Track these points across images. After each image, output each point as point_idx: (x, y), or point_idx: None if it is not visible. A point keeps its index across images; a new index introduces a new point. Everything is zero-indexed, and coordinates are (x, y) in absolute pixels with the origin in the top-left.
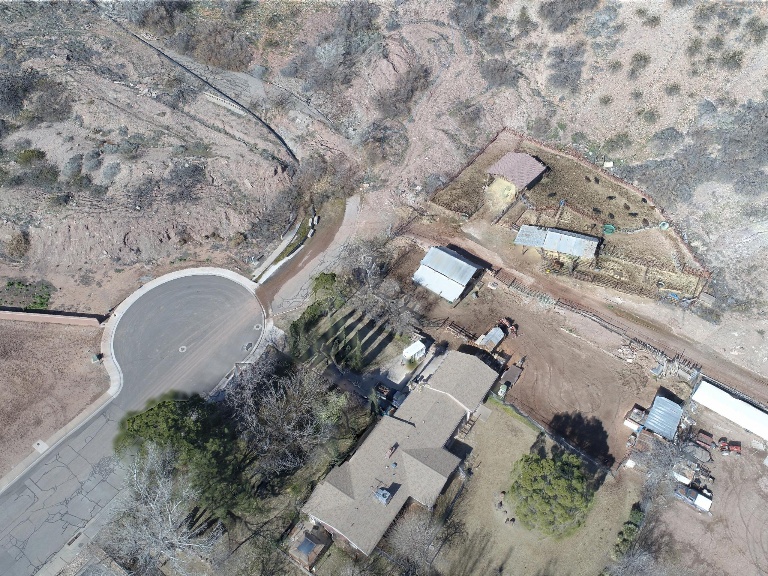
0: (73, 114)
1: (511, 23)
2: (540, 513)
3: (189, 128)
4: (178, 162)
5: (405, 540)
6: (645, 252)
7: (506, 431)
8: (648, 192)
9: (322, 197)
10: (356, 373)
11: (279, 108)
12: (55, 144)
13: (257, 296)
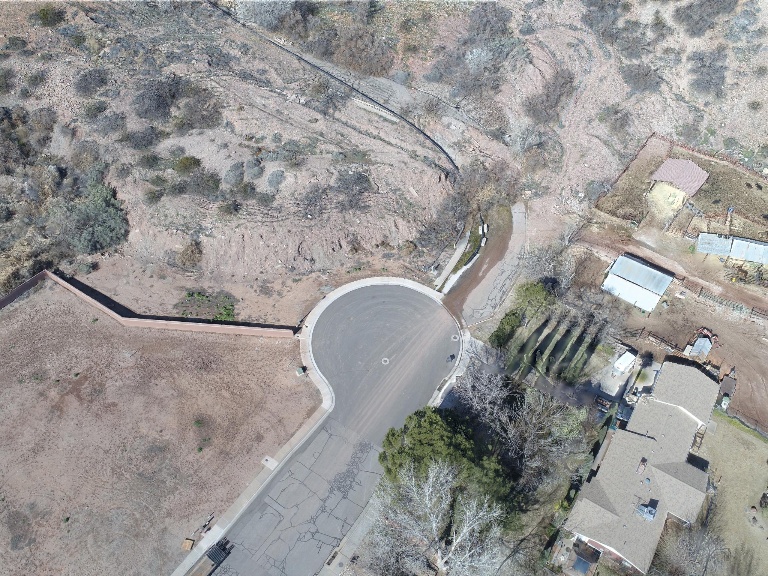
0: (223, 121)
1: (645, 27)
2: None
3: (343, 135)
4: (341, 169)
5: (675, 558)
6: None
7: (737, 444)
8: None
9: (489, 205)
10: (568, 385)
11: (431, 114)
12: (210, 151)
13: (445, 306)
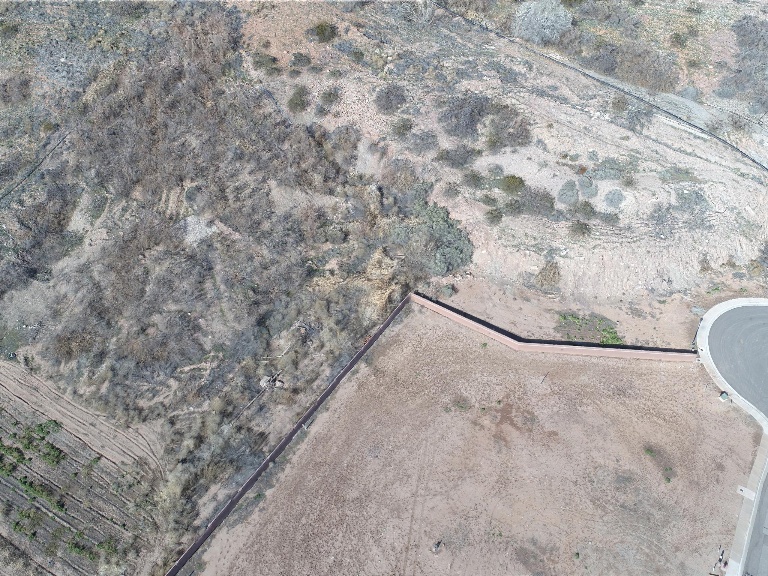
0: (534, 138)
1: None
2: None
3: (657, 152)
4: (676, 188)
5: None
6: None
7: None
8: None
9: None
10: None
11: (740, 131)
12: (530, 170)
13: None
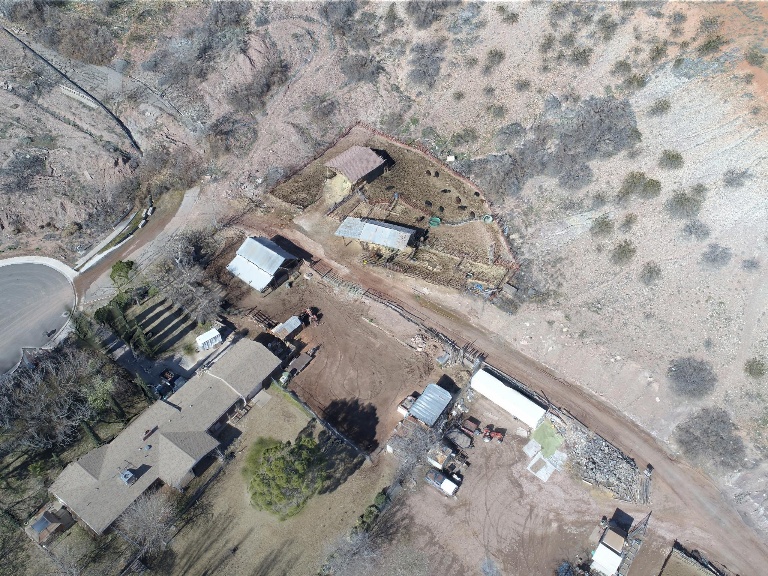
0: None
1: (379, 19)
2: (258, 493)
3: (40, 120)
4: (20, 153)
5: (143, 520)
6: (464, 244)
7: (280, 416)
8: (481, 186)
9: (159, 188)
10: (149, 359)
11: (131, 101)
12: None
13: (74, 284)
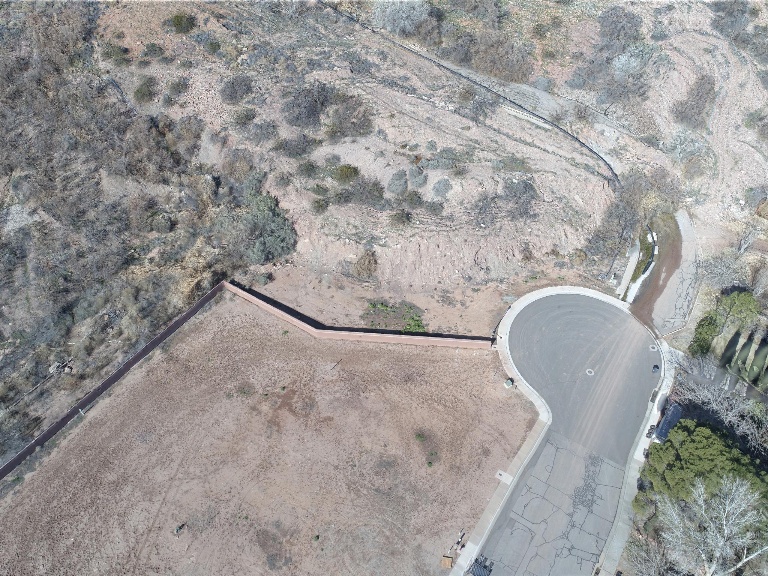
0: (375, 128)
1: None
2: None
3: (497, 142)
4: (506, 178)
5: None
6: None
7: None
8: None
9: (655, 212)
10: None
11: (583, 121)
12: (366, 159)
13: (635, 316)
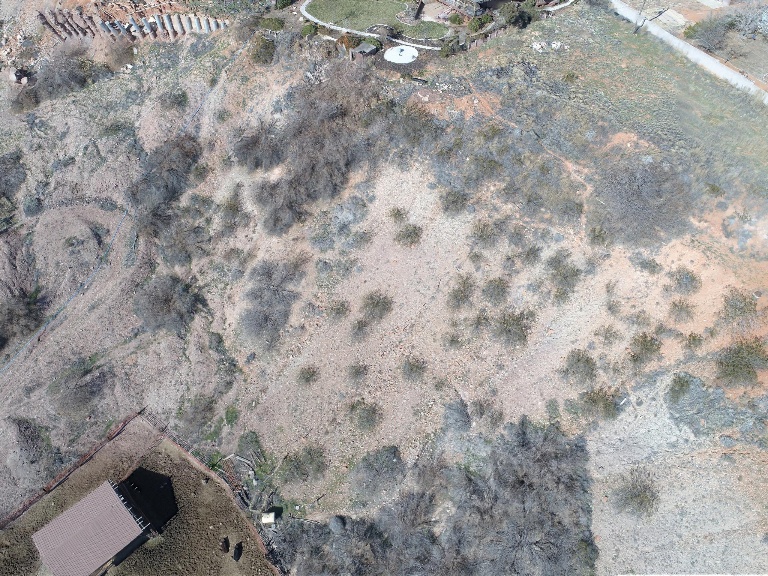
0: None
1: (216, 209)
2: None
3: None
4: None
5: None
6: None
7: None
8: None
9: None
10: None
11: None
12: None
13: None
